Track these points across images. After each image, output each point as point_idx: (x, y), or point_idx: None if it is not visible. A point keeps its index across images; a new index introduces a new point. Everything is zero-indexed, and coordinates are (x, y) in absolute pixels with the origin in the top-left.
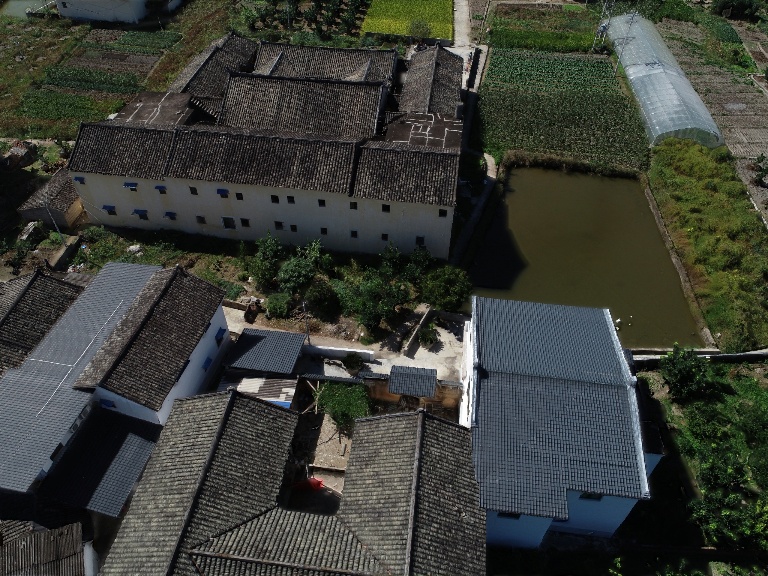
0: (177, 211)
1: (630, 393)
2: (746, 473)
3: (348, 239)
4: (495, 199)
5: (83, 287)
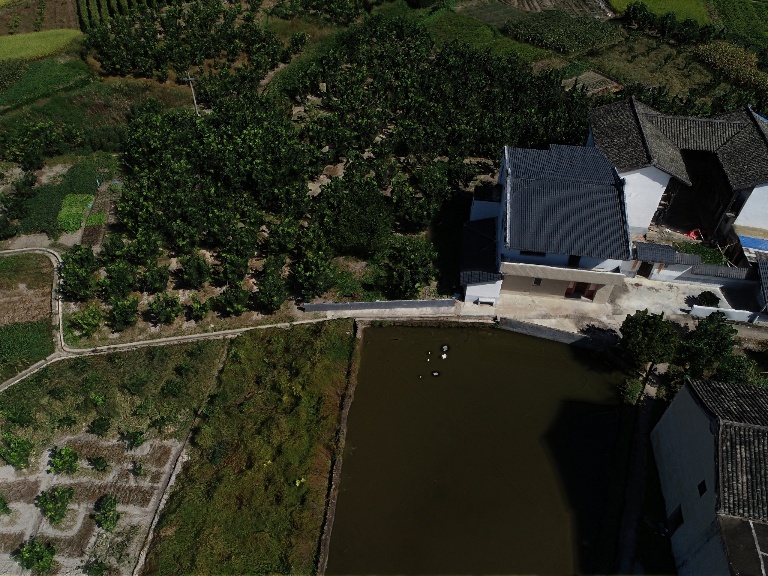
0: None
1: None
2: None
3: None
4: (603, 570)
5: None
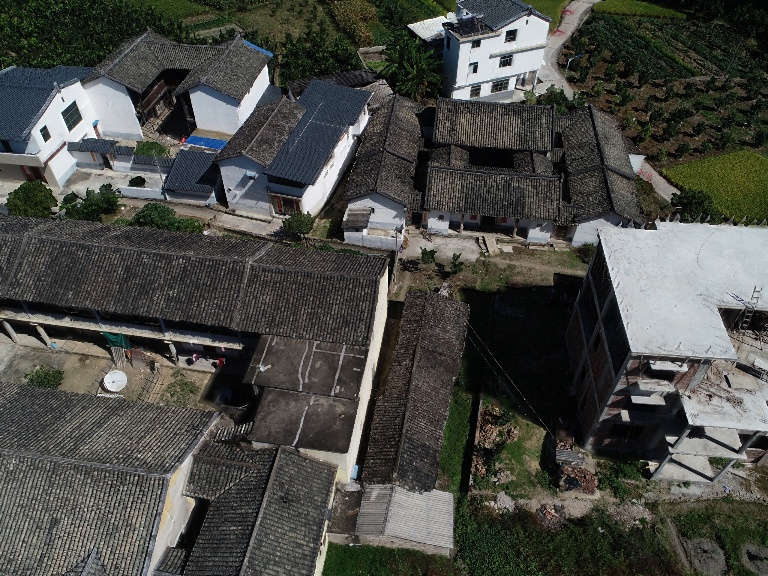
0: None
1: None
2: None
3: None
4: None
5: (342, 200)
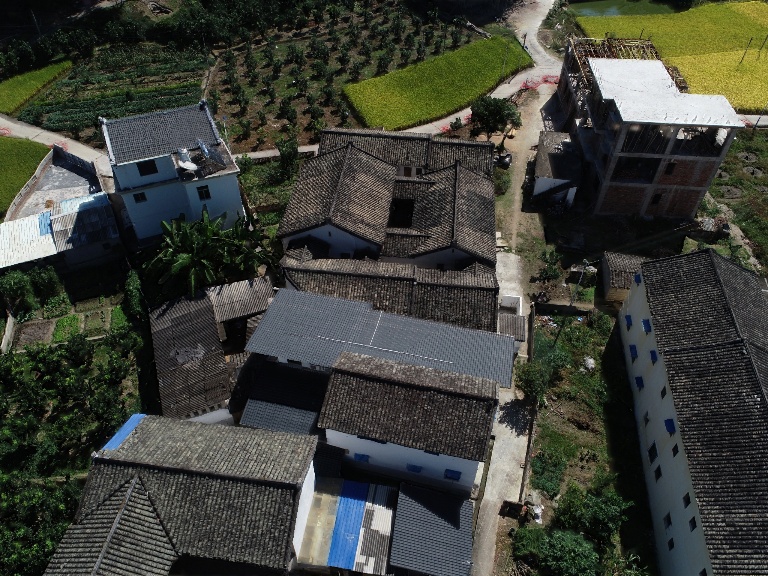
0: (646, 387)
1: None
2: None
3: None
4: None
5: (496, 330)
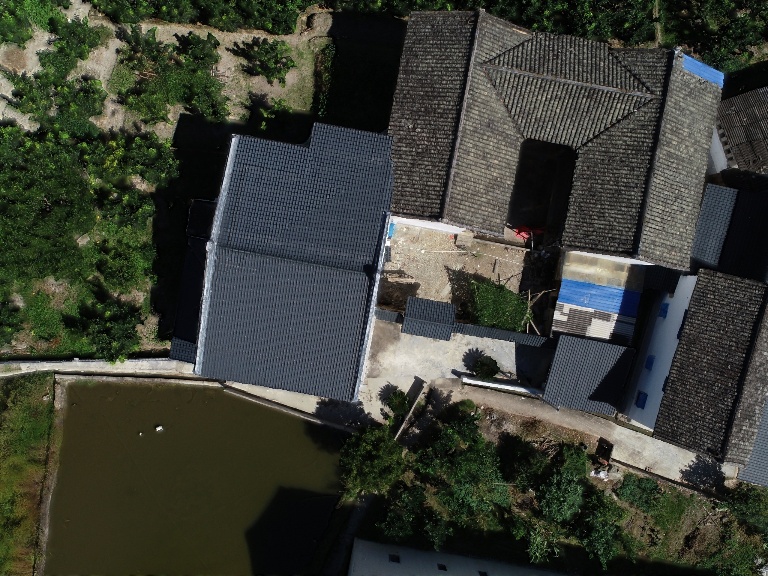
0: None
1: (216, 237)
2: (98, 224)
3: (490, 571)
4: None
5: None
